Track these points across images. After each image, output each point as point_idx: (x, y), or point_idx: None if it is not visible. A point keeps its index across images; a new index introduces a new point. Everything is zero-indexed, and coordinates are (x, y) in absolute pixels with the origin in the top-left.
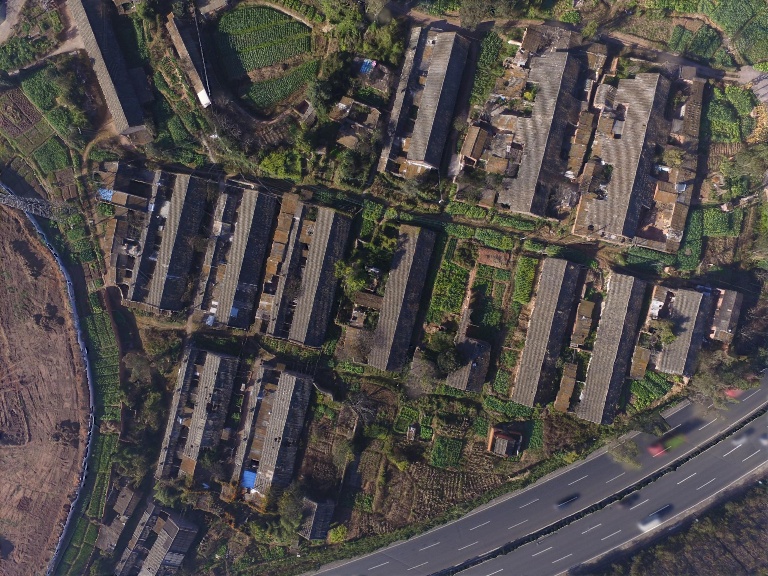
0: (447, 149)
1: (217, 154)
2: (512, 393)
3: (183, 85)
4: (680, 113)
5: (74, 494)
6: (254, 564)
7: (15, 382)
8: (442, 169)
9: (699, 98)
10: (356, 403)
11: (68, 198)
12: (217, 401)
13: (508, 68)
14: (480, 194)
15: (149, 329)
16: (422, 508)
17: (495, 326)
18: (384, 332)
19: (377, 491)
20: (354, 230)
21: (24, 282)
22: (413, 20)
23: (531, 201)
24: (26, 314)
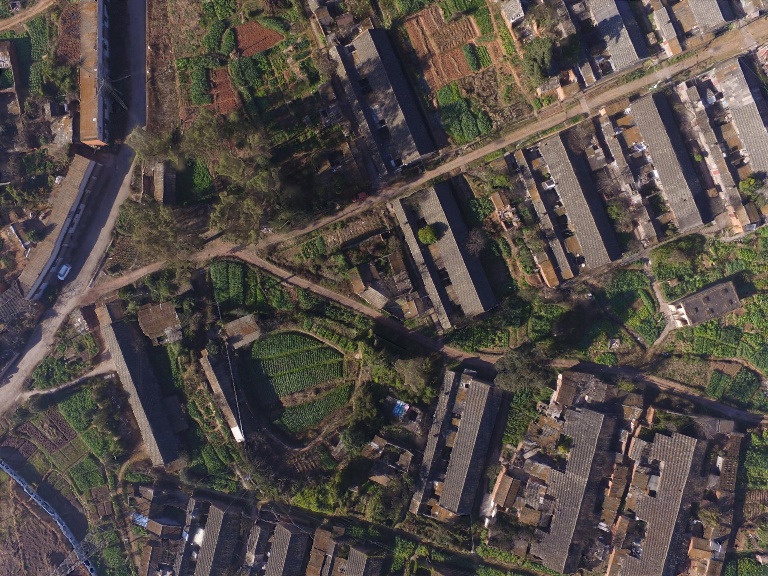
0: (479, 488)
1: None
2: None
3: (217, 420)
4: (716, 462)
5: None
6: None
7: None
8: (474, 508)
9: (736, 451)
10: None
11: (103, 515)
12: None
13: (542, 413)
14: (512, 542)
15: None
16: None
17: None
18: None
19: None
20: (385, 563)
21: None
22: (446, 356)
23: (564, 563)
24: None
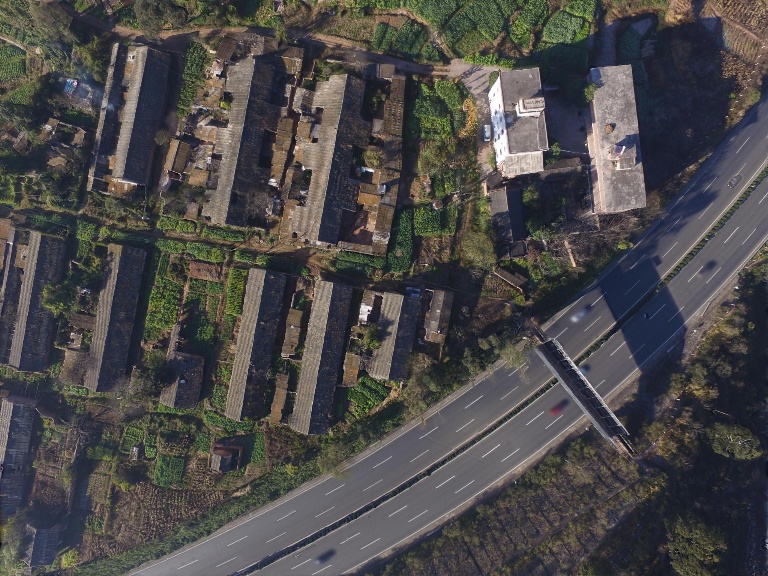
0: (158, 164)
1: None
2: None
3: None
4: None
5: None
6: None
7: None
8: (154, 184)
9: (400, 96)
10: (76, 426)
11: None
12: None
13: None
14: (185, 208)
15: None
16: (148, 528)
17: (208, 340)
18: (96, 353)
19: (106, 513)
20: (72, 251)
21: None
22: (118, 36)
23: (226, 212)
24: None
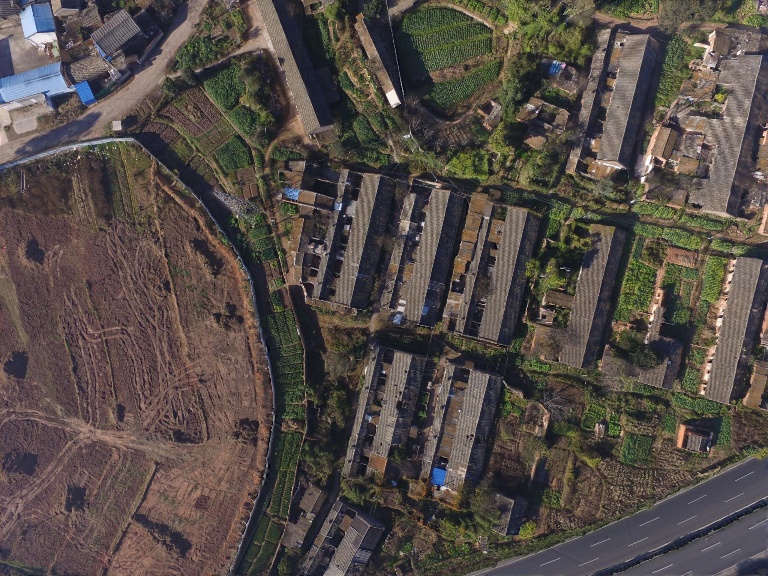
0: (633, 150)
1: (402, 154)
2: (702, 390)
3: (372, 85)
4: None
5: (255, 492)
6: (441, 561)
7: (193, 381)
8: (628, 169)
9: None
10: (547, 400)
11: (249, 197)
12: (407, 399)
13: (695, 70)
14: (670, 194)
15: (332, 328)
16: (612, 504)
17: (685, 324)
18: (577, 330)
19: (565, 487)
20: (540, 229)
21: (203, 281)
22: (598, 22)
23: (727, 201)
24: (205, 313)
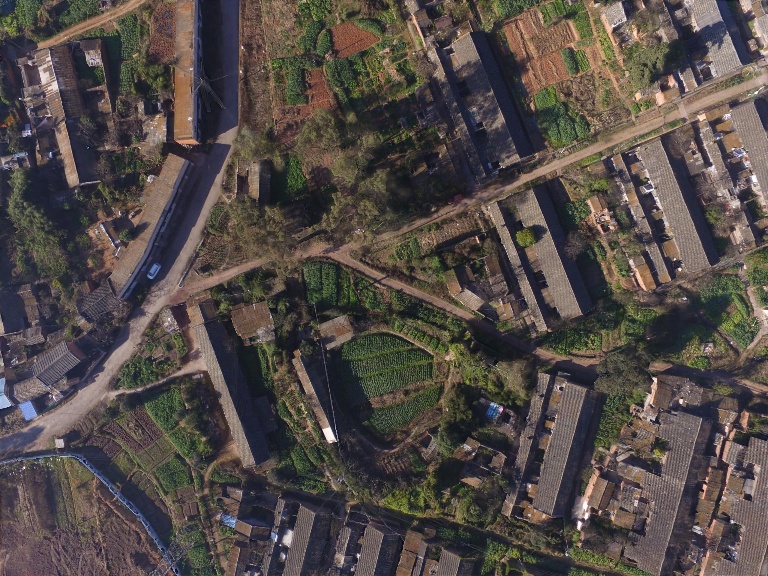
0: (571, 490)
1: (339, 484)
2: None
3: None
4: None
5: None
6: None
7: None
8: (565, 510)
9: None
10: None
11: (189, 515)
12: None
13: (635, 416)
14: (606, 545)
15: None
16: None
17: None
18: None
19: None
20: (475, 565)
21: None
22: (539, 358)
23: (661, 565)
24: None
